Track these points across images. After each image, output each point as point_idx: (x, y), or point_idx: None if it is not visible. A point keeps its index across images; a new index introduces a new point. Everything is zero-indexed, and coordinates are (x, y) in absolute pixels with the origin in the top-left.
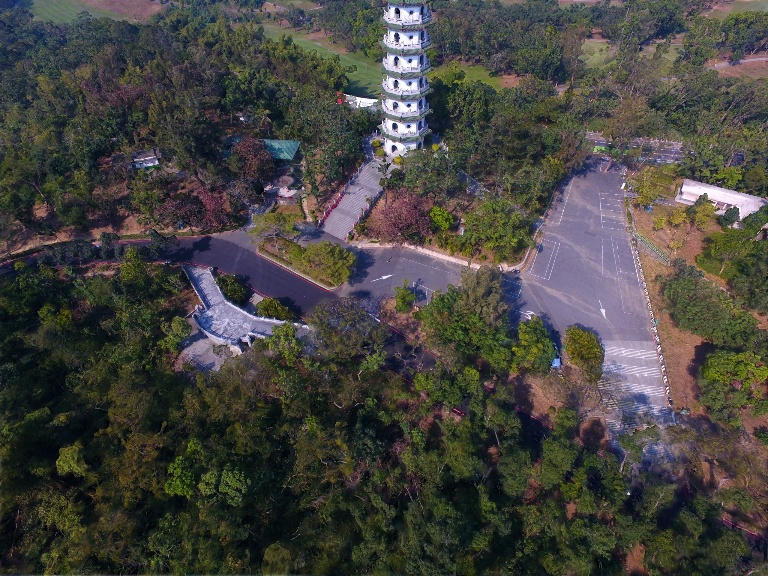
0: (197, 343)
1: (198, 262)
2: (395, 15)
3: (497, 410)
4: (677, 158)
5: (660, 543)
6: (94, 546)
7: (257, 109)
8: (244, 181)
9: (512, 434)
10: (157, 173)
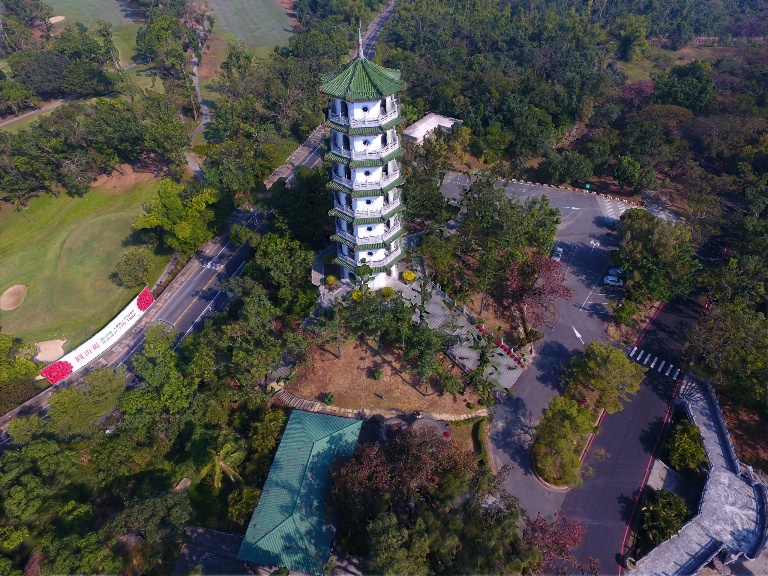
0: (754, 570)
1: None
2: (381, 111)
3: None
4: None
5: None
6: None
7: None
8: None
9: None
10: None
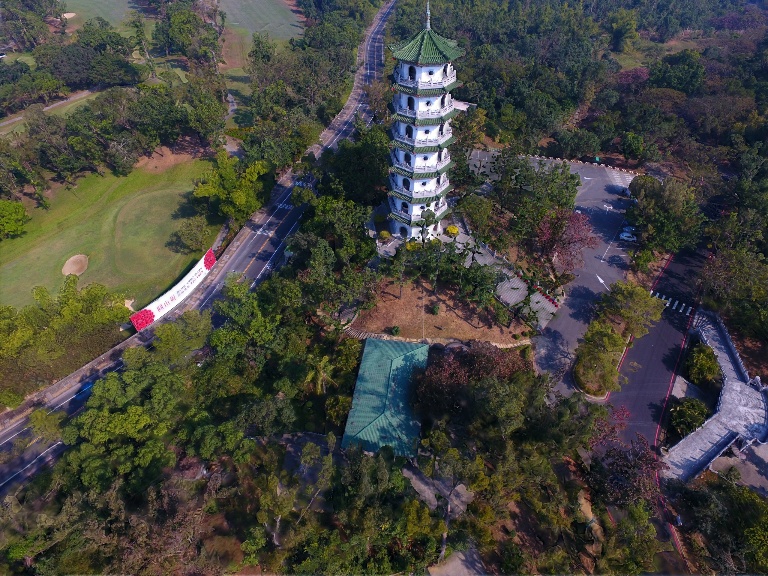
0: (765, 457)
1: None
2: (443, 75)
3: None
4: (368, 116)
5: None
6: None
7: (258, 402)
8: None
9: None
10: (521, 567)
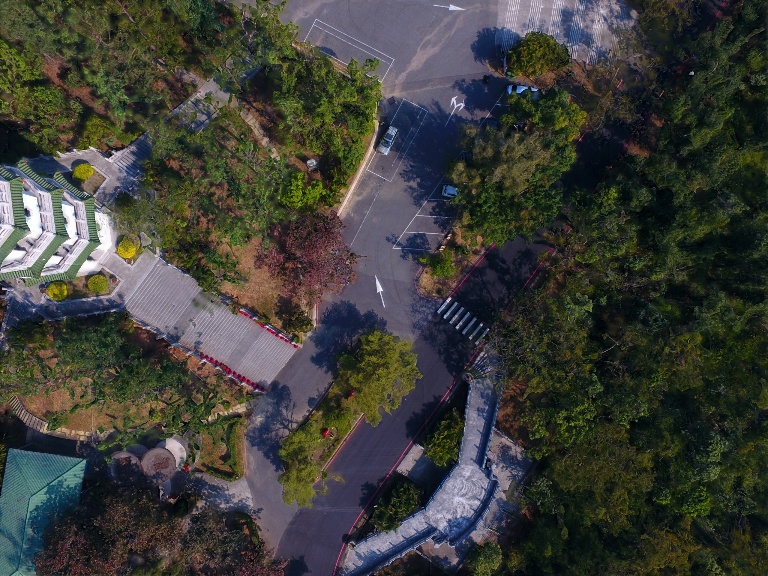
0: None
1: (330, 568)
2: None
3: (682, 178)
4: None
5: (752, 64)
6: (766, 563)
7: None
8: (182, 542)
9: (641, 167)
10: None
